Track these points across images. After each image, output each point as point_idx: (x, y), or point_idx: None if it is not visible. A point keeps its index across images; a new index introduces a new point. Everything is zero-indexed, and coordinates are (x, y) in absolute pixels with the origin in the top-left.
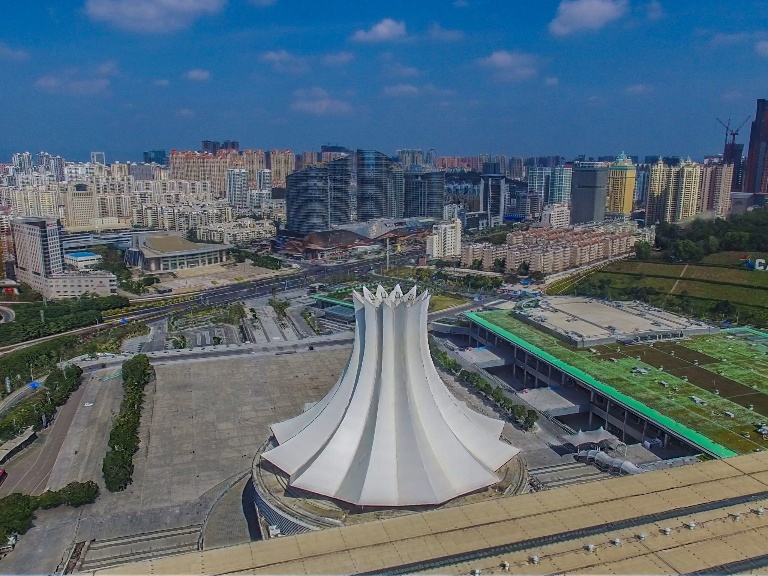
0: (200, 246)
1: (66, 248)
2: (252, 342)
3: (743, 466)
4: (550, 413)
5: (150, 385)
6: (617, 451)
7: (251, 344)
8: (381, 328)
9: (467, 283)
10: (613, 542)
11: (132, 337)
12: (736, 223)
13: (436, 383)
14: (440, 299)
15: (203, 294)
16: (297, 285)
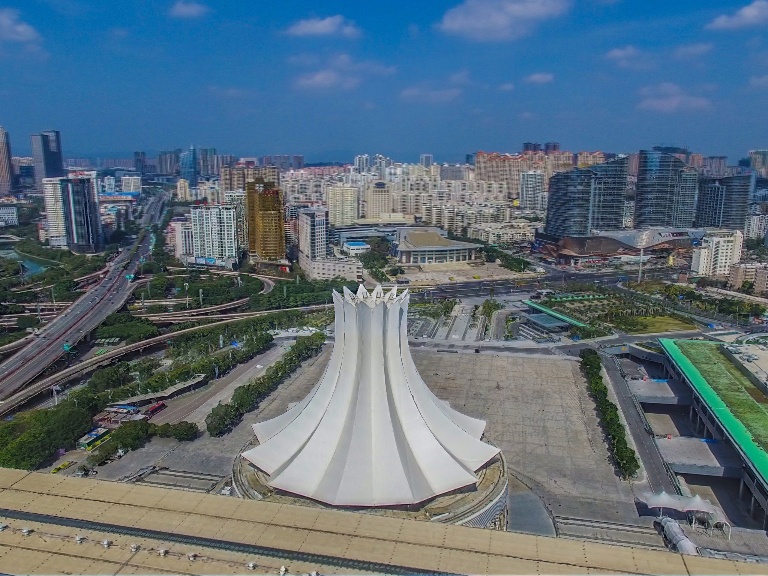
0: (452, 243)
1: (348, 237)
2: (429, 337)
3: (702, 571)
4: (679, 467)
5: (312, 359)
6: (722, 531)
7: (428, 338)
8: None
9: (718, 307)
10: None
11: None
12: None
13: (404, 390)
14: (663, 321)
15: (434, 288)
16: (528, 289)
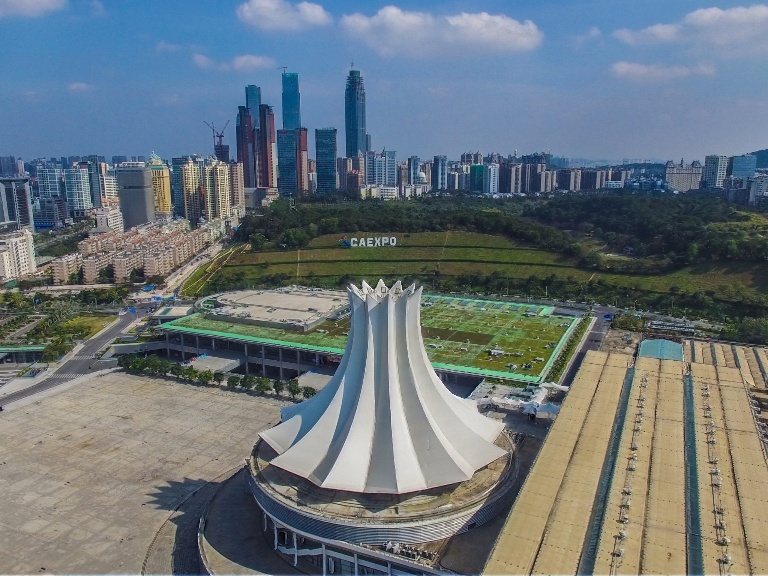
0: None
1: None
2: None
3: (596, 362)
4: None
5: None
6: None
7: None
8: (403, 320)
9: (87, 300)
10: (638, 422)
11: None
12: (306, 212)
13: None
14: (84, 321)
15: None
16: None
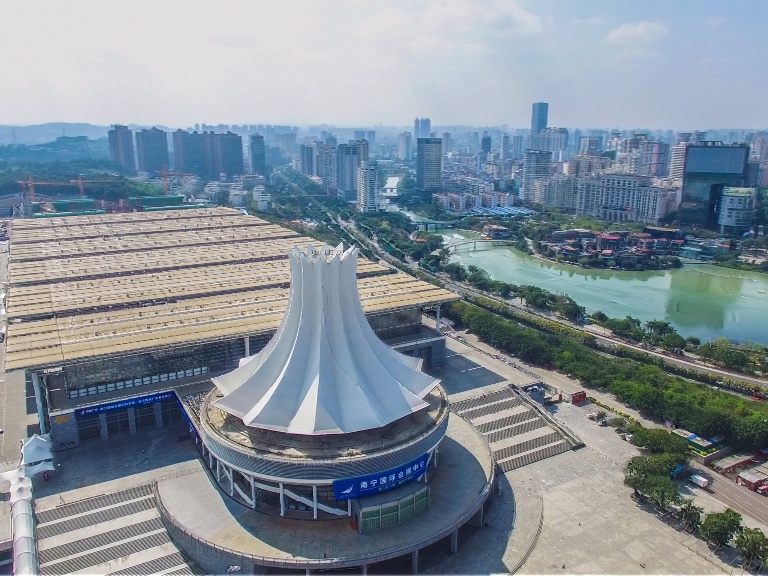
0: None
1: None
2: None
3: (55, 357)
4: None
5: None
6: None
7: None
8: None
9: None
10: (199, 320)
11: None
12: None
13: None
14: None
15: None
16: None
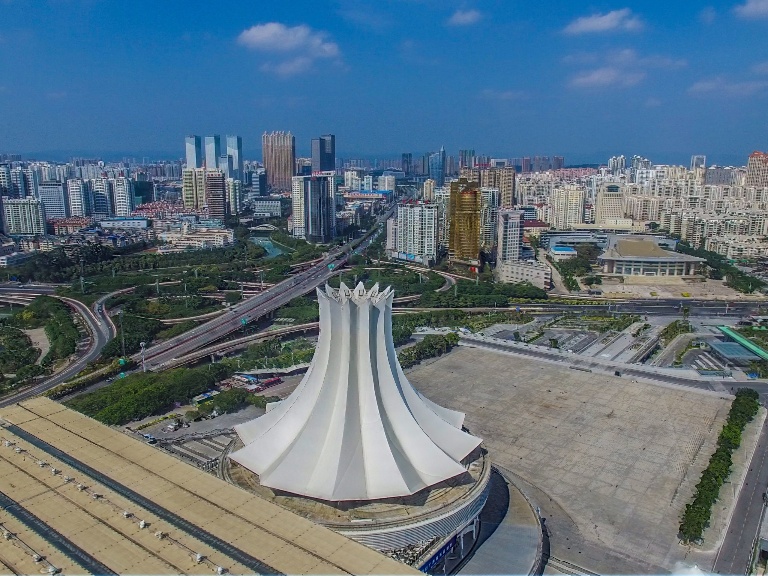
0: (668, 255)
1: (558, 242)
2: (575, 352)
3: None
4: None
5: (435, 358)
6: None
7: (573, 353)
8: None
9: None
10: (223, 570)
11: (506, 323)
12: None
13: (369, 390)
14: None
15: (626, 302)
16: (743, 314)
